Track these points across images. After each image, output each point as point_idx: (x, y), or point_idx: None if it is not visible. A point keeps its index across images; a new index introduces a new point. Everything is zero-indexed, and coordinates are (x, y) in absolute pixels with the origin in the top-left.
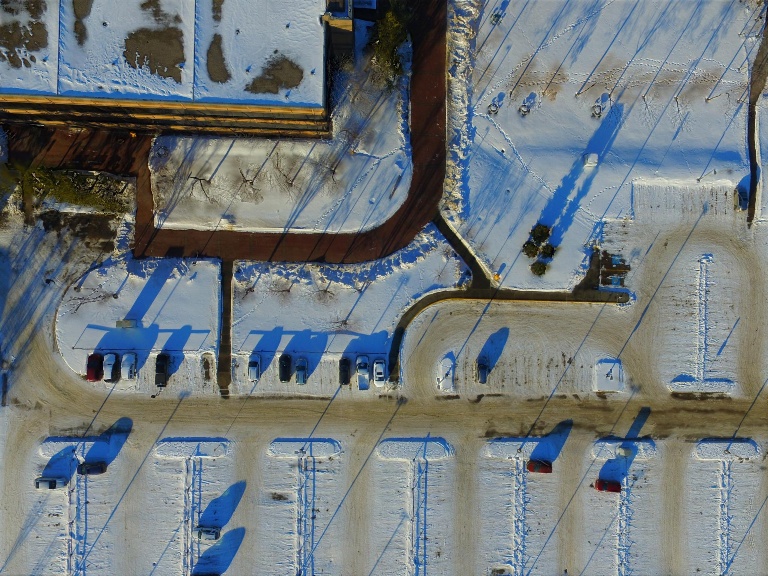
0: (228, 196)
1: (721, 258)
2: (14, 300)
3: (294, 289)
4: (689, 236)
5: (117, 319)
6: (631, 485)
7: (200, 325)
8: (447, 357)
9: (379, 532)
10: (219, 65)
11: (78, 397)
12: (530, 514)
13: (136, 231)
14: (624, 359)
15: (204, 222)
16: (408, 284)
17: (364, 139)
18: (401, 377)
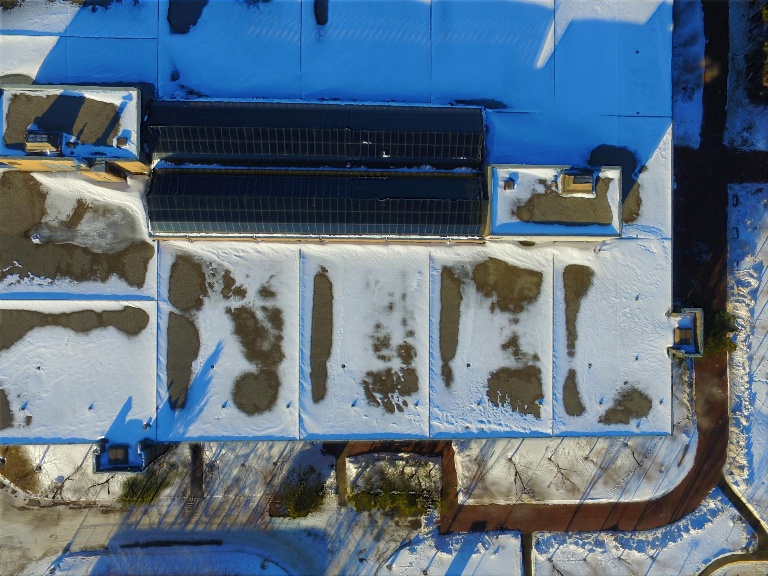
0: (528, 472)
1: None
2: None
3: (590, 558)
4: None
5: None
6: None
7: None
8: None
9: None
10: (574, 399)
11: None
12: None
13: (441, 508)
14: None
15: (505, 497)
16: (697, 549)
17: None
18: None
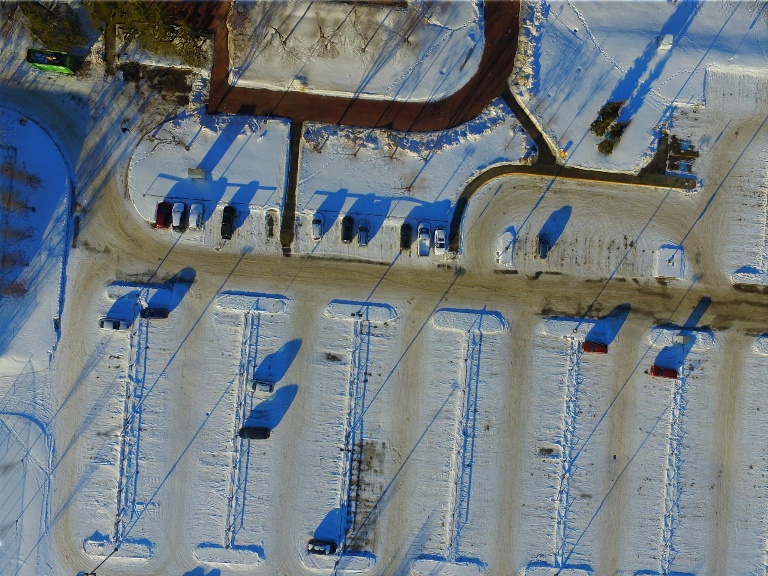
0: (302, 57)
1: None
2: (91, 146)
3: (360, 153)
4: (761, 126)
5: None
6: (687, 375)
7: (267, 182)
8: (508, 231)
9: (429, 401)
10: None
11: (145, 244)
12: (582, 395)
13: (211, 87)
14: (687, 246)
15: (277, 82)
16: (473, 156)
17: (438, 10)
18: (461, 248)
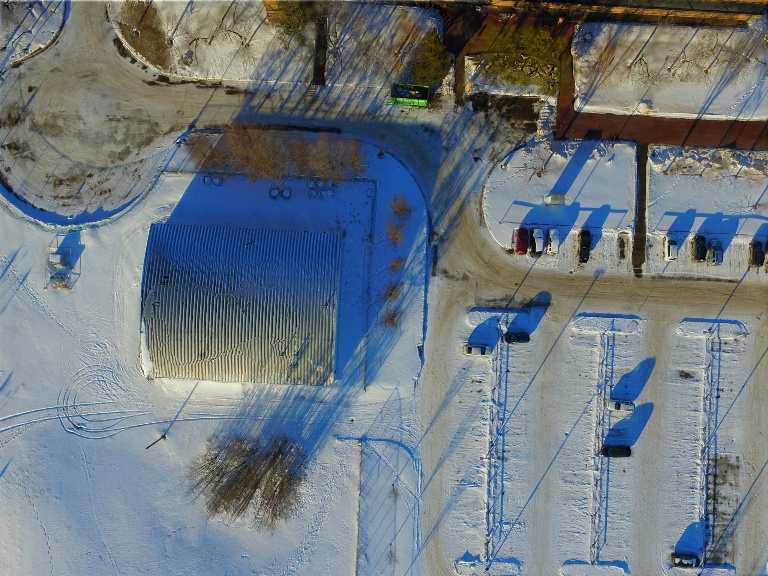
0: (647, 81)
1: None
2: (444, 176)
3: (706, 173)
4: None
5: (541, 196)
6: None
7: (618, 205)
8: None
9: None
10: None
11: (502, 270)
12: None
13: (558, 114)
14: None
15: (622, 106)
16: None
17: None
18: None
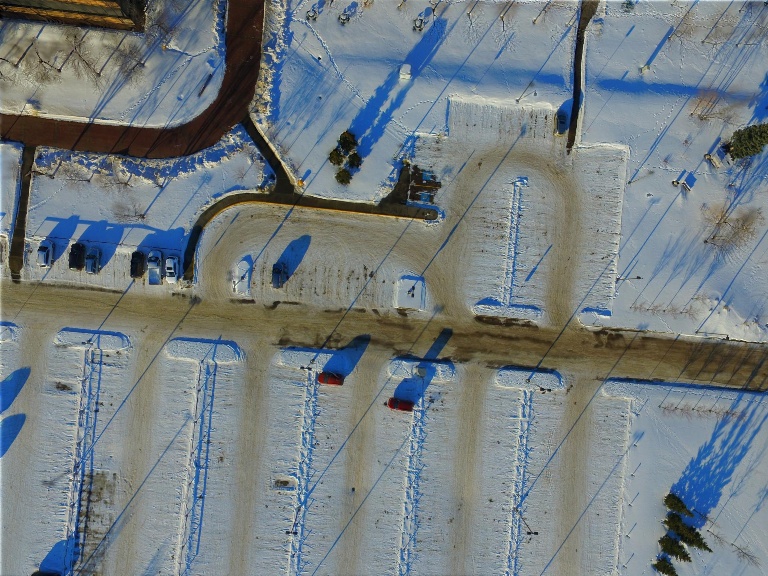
0: None
1: (536, 182)
2: None
3: (94, 179)
4: (505, 157)
5: None
6: (427, 407)
7: None
8: (244, 260)
9: (162, 431)
10: None
11: None
12: (319, 427)
13: None
14: (428, 277)
15: (9, 106)
16: (210, 183)
17: (177, 35)
18: (196, 276)
